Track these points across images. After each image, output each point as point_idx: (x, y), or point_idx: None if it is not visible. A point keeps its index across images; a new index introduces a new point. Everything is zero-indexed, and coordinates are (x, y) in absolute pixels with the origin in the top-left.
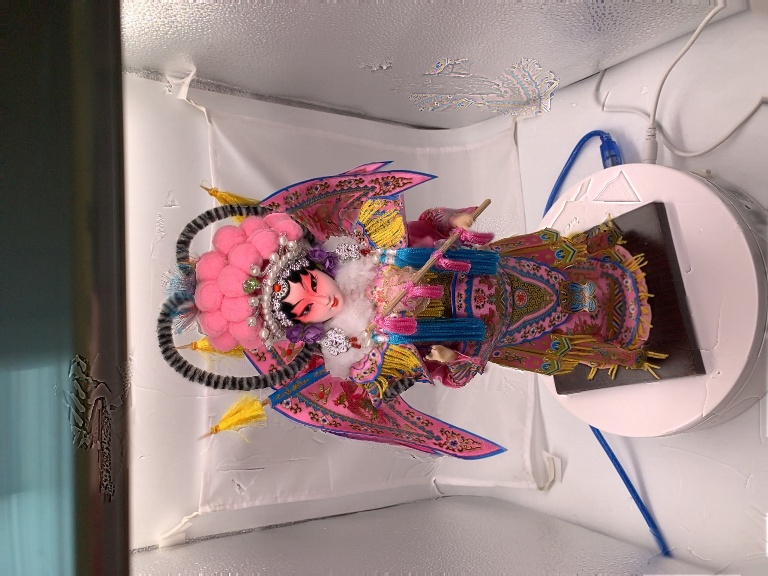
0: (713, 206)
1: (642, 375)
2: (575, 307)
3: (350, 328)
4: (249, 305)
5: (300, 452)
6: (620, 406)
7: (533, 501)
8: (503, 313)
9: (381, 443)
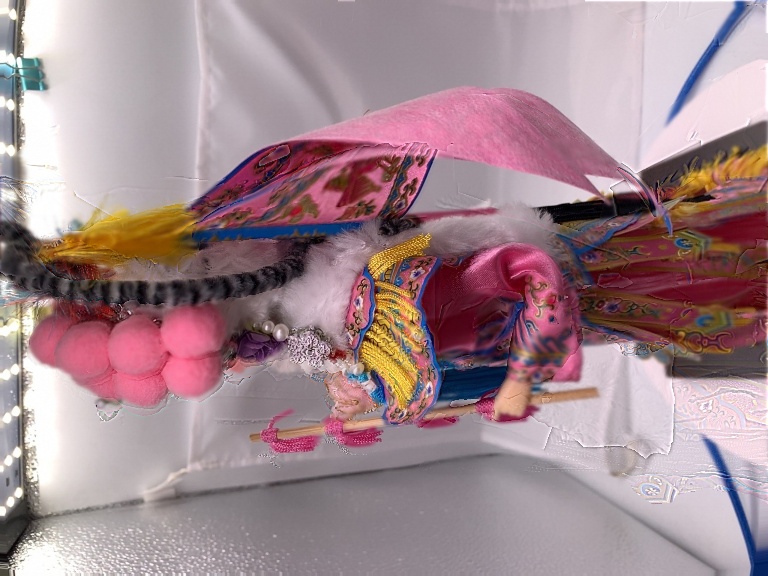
0: None
1: None
2: None
3: None
4: None
5: None
6: None
7: None
8: None
9: None
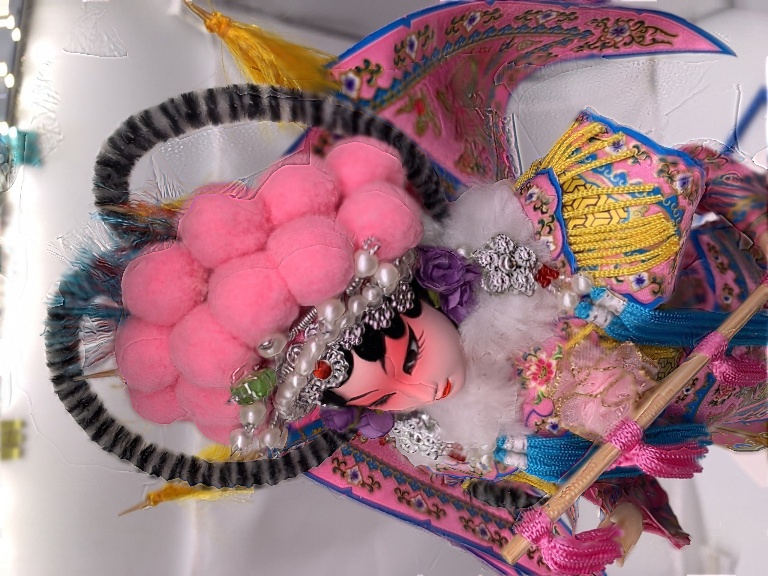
0: None
1: None
2: None
3: (457, 438)
4: None
5: (302, 502)
6: None
7: None
8: None
9: (438, 536)
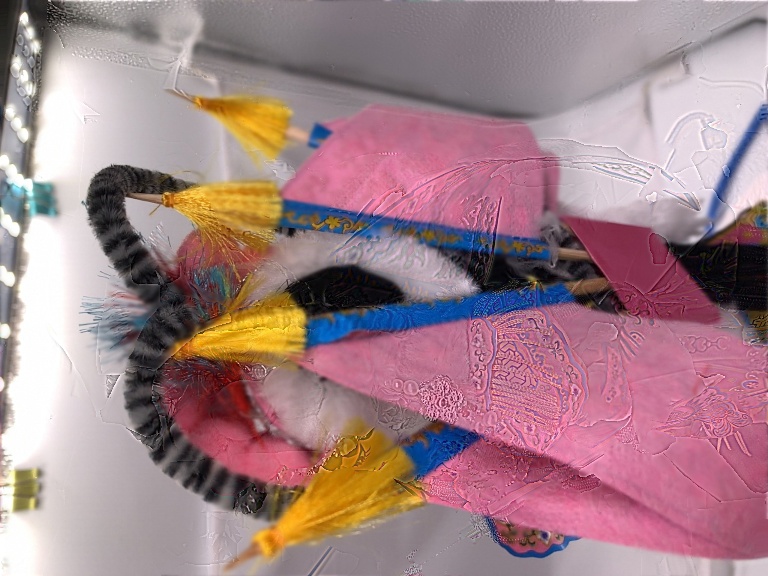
0: None
1: None
2: (703, 417)
3: None
4: None
5: None
6: None
7: None
8: None
9: None
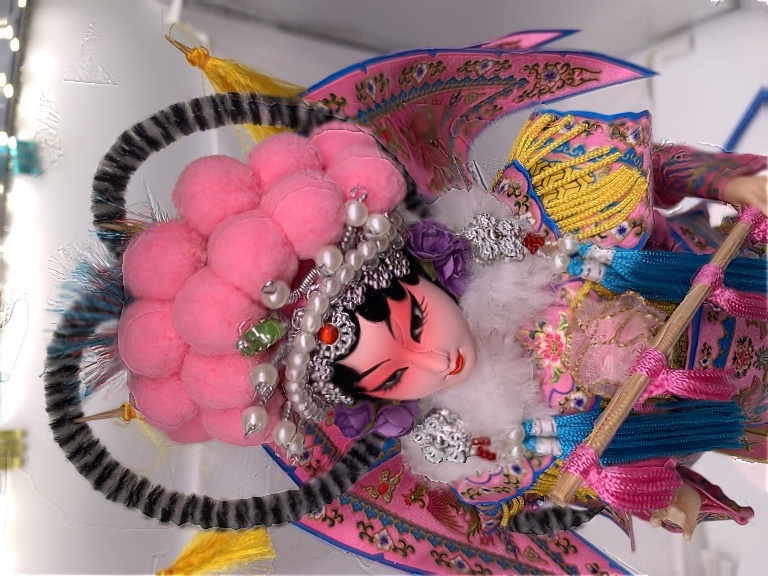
0: None
1: None
2: None
3: (482, 423)
4: (251, 380)
5: None
6: None
7: None
8: None
9: None
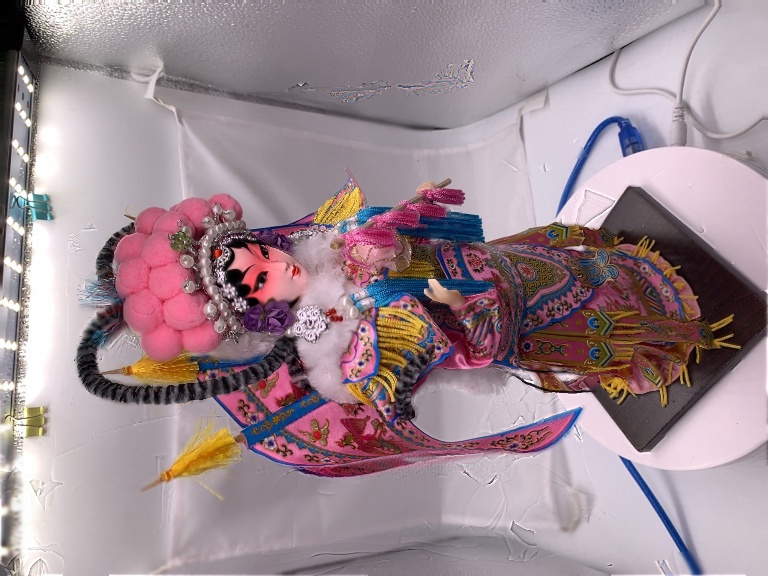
0: (687, 155)
1: (719, 358)
2: (596, 281)
3: (322, 295)
4: (182, 268)
5: (304, 515)
6: (717, 419)
7: (669, 556)
8: (511, 281)
9: (412, 464)
